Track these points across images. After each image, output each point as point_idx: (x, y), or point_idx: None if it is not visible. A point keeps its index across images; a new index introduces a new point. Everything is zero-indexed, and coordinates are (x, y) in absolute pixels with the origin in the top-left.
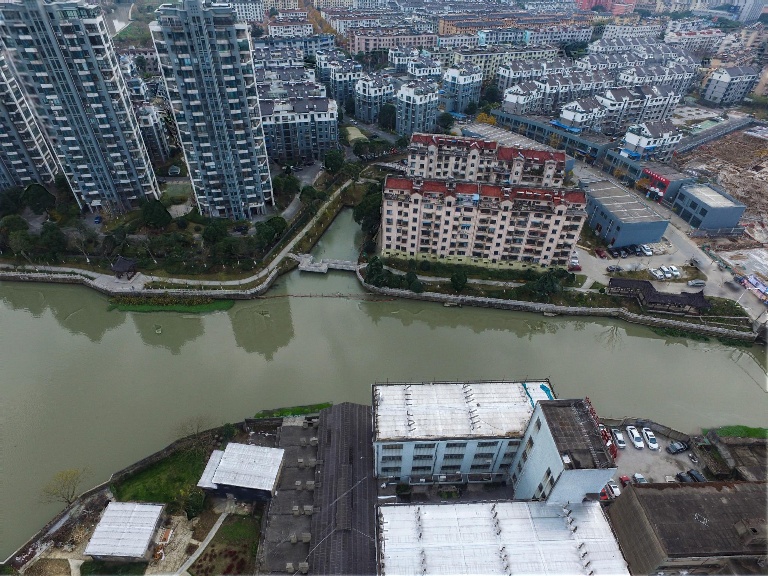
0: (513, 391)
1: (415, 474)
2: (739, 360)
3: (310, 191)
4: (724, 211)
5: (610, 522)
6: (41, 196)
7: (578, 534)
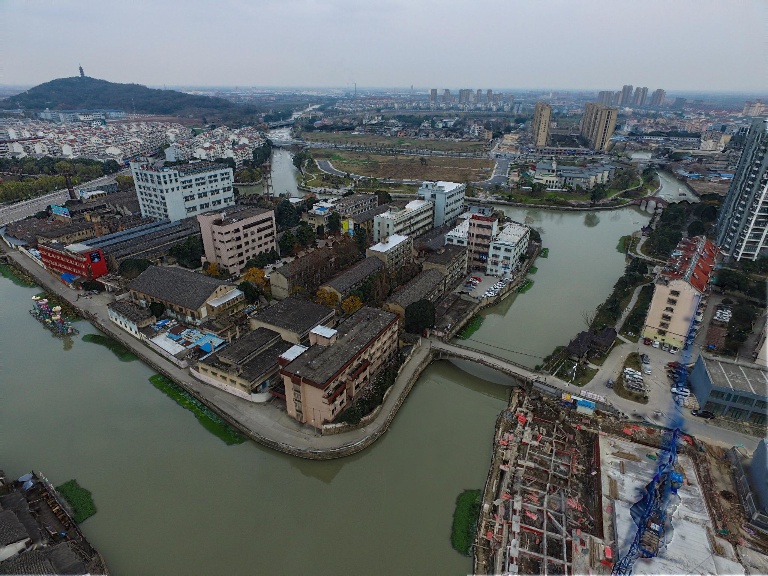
0: None
1: None
2: None
3: (746, 262)
4: None
5: None
6: (707, 211)
7: None
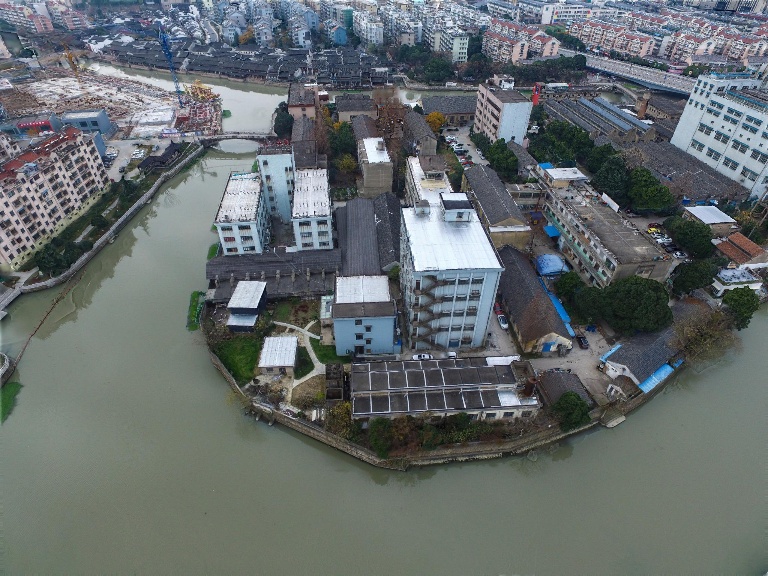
0: (235, 183)
1: (263, 240)
2: (207, 166)
3: None
4: (101, 117)
5: (305, 168)
6: None
7: (309, 176)
